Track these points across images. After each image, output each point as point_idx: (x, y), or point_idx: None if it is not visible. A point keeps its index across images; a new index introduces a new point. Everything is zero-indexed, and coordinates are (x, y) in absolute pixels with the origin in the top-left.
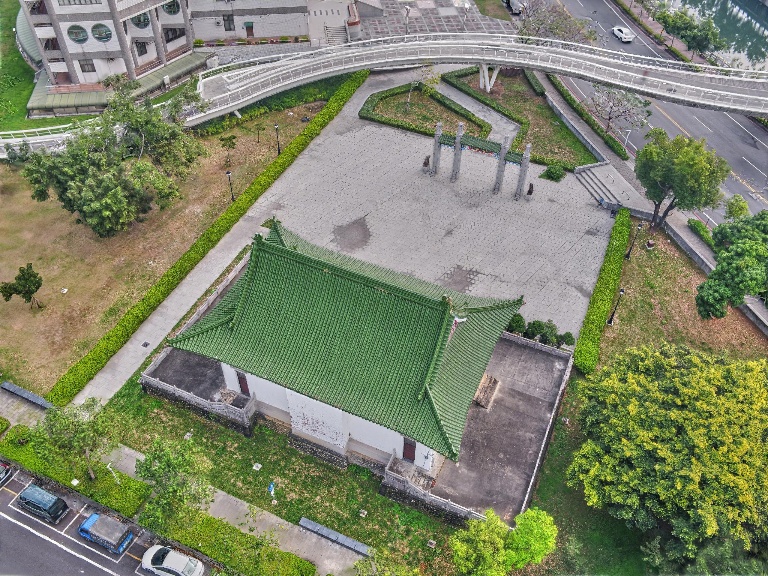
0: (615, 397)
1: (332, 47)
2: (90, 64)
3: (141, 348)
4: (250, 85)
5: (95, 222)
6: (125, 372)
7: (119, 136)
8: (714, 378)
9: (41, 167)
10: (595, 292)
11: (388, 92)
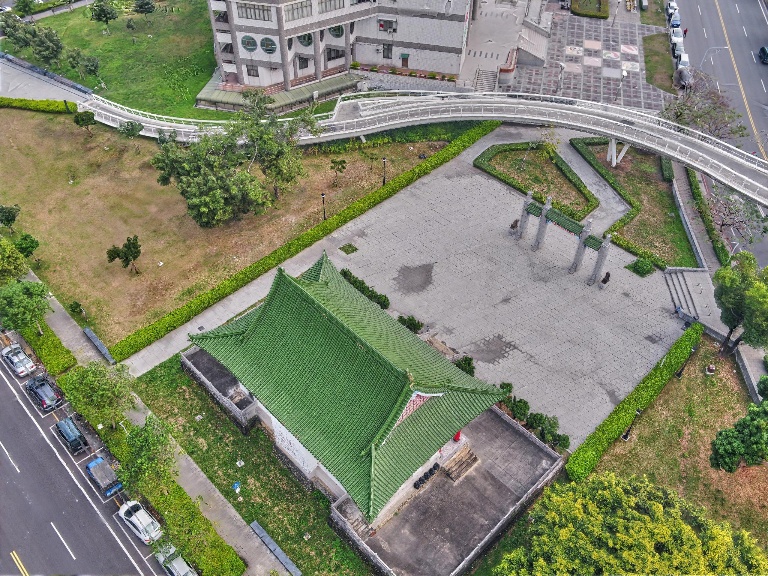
0: (554, 516)
1: (467, 93)
2: (255, 70)
3: (196, 330)
4: (378, 116)
5: (193, 214)
6: (176, 347)
7: (241, 143)
8: (658, 533)
9: (167, 158)
10: (623, 402)
11: (510, 146)
